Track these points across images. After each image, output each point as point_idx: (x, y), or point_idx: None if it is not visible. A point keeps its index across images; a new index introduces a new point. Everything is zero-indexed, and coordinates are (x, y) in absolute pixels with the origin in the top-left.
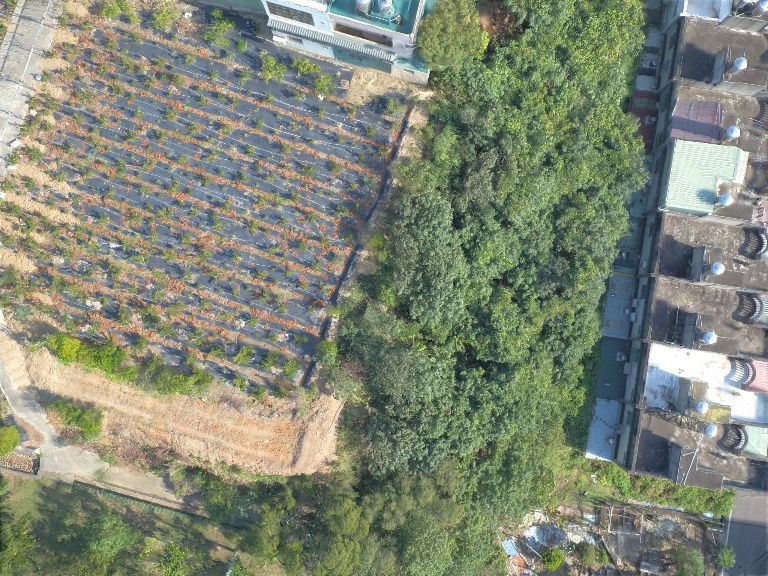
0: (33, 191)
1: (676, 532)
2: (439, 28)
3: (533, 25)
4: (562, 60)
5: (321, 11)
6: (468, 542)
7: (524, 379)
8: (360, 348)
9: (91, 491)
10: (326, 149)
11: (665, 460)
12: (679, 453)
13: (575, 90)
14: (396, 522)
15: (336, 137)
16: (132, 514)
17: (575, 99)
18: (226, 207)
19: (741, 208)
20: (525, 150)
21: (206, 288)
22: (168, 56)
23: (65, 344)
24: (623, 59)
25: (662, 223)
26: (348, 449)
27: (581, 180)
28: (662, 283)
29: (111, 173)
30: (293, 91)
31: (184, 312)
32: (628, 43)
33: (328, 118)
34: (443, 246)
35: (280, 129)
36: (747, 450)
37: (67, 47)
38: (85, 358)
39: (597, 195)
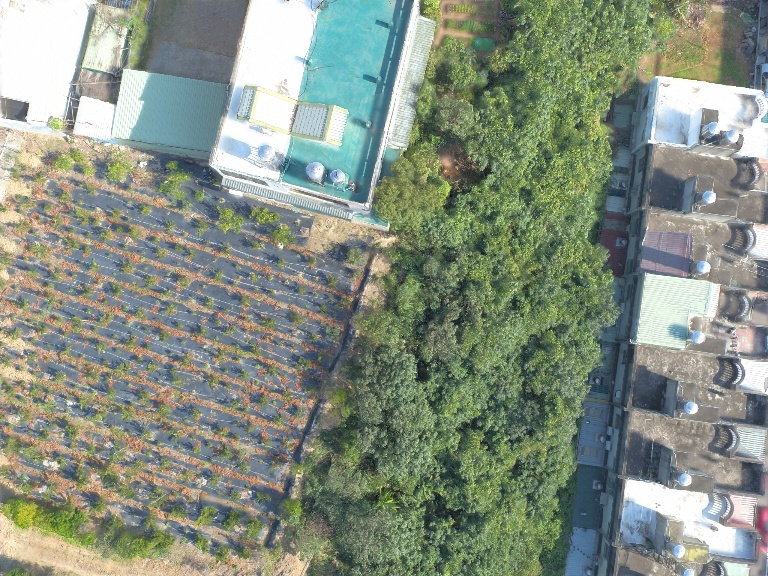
0: None
1: None
2: (395, 195)
3: (495, 171)
4: (527, 200)
5: (273, 181)
6: None
7: (495, 528)
8: (324, 508)
9: None
10: (287, 299)
11: None
12: None
13: (541, 228)
14: None
15: (297, 287)
16: None
17: (541, 237)
18: (185, 362)
19: (714, 342)
20: (490, 298)
21: (166, 445)
22: (123, 207)
23: (21, 511)
24: (591, 186)
25: (634, 356)
26: None
27: (549, 322)
28: (636, 416)
29: (67, 328)
30: (252, 241)
31: (144, 471)
32: (595, 172)
33: (288, 267)
34: (407, 404)
35: (239, 280)
36: None
37: (20, 199)
38: (42, 524)
39: (566, 333)
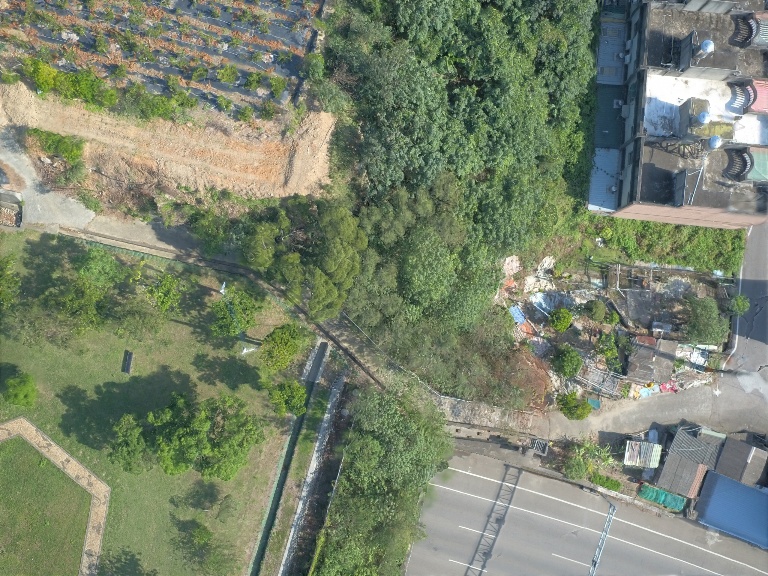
0: None
1: (687, 292)
2: None
3: None
4: None
5: None
6: (472, 280)
7: (519, 96)
8: (348, 57)
9: (77, 241)
10: None
11: (670, 192)
12: (684, 174)
13: None
14: (395, 233)
15: None
16: (121, 262)
17: None
18: None
19: None
20: None
21: (185, 13)
22: None
23: (41, 68)
24: None
25: None
26: (342, 171)
27: None
28: (655, 12)
29: None
30: None
31: (164, 39)
32: None
33: None
34: None
35: None
36: (754, 178)
37: None
38: (63, 84)
39: None
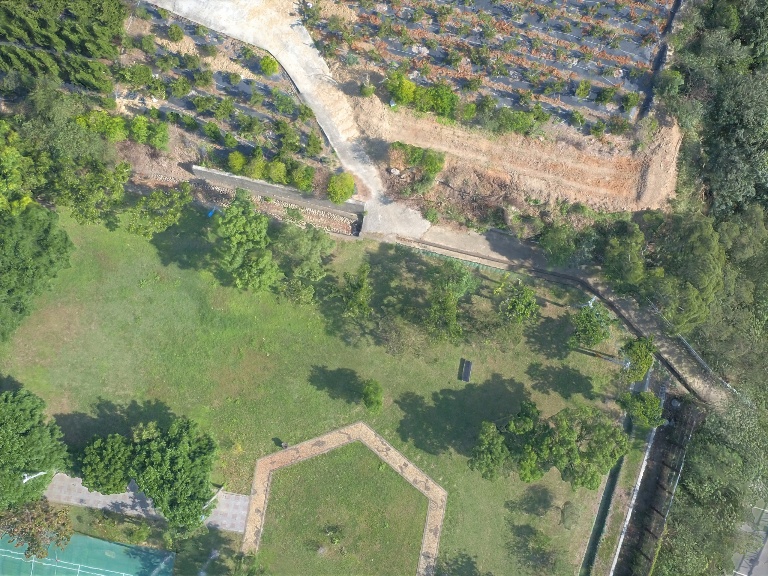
0: None
1: None
2: None
3: None
4: None
5: None
6: None
7: None
8: (706, 73)
9: (414, 251)
10: None
11: None
12: None
13: None
14: (753, 249)
15: None
16: None
17: None
18: None
19: None
20: None
21: (535, 28)
22: None
23: (405, 82)
24: None
25: None
26: (688, 186)
27: None
28: None
29: None
30: None
31: (514, 53)
32: None
33: None
34: None
35: None
36: None
37: None
38: (423, 97)
39: None
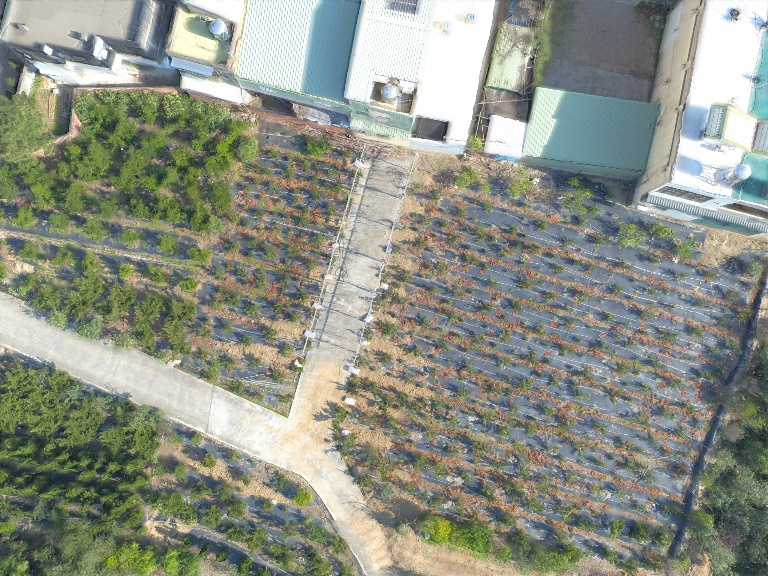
0: (387, 366)
1: None
2: None
3: None
4: None
5: (731, 198)
6: None
7: None
8: (738, 520)
9: None
10: (683, 313)
11: None
12: None
13: None
14: None
15: (693, 301)
16: None
17: None
18: (589, 377)
19: None
20: None
21: (569, 459)
22: (518, 223)
23: (441, 528)
24: None
25: None
26: None
27: None
28: None
29: (466, 344)
30: (650, 257)
31: (548, 485)
32: None
33: (684, 282)
34: None
35: (636, 294)
36: None
37: (414, 217)
38: (459, 540)
39: None
